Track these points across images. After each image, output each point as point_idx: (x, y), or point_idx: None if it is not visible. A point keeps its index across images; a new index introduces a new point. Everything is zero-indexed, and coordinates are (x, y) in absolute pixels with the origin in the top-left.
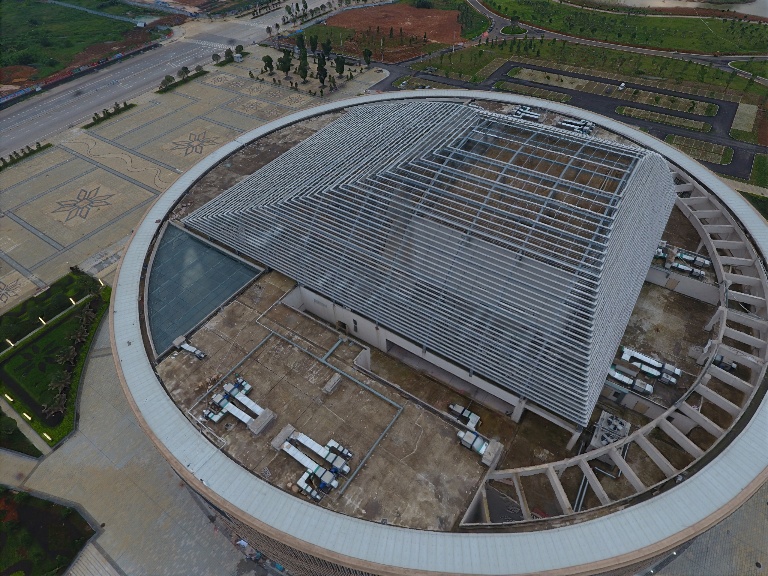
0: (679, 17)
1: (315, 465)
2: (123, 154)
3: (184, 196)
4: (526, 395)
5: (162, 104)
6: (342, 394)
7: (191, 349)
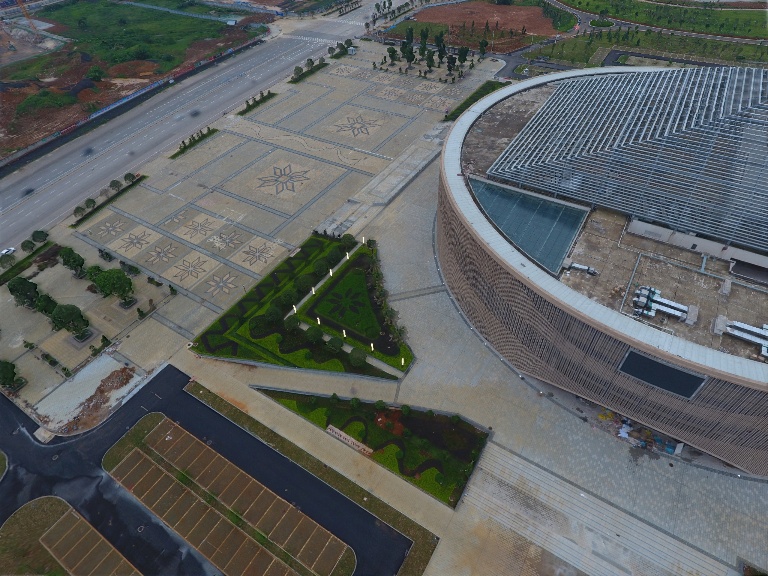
0: (749, 10)
1: (766, 342)
2: (293, 136)
3: (461, 156)
4: None
5: (301, 93)
6: (738, 295)
7: (583, 267)
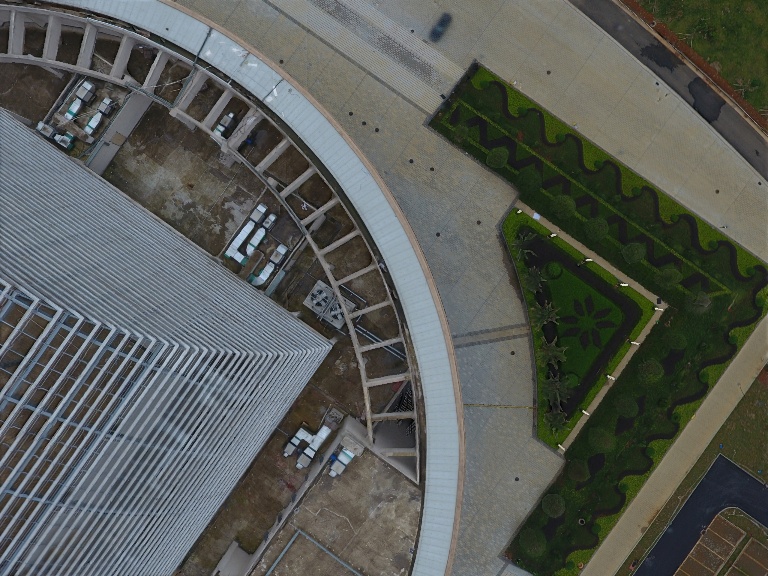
0: None
1: None
2: None
3: None
4: (293, 400)
5: None
6: None
7: None
